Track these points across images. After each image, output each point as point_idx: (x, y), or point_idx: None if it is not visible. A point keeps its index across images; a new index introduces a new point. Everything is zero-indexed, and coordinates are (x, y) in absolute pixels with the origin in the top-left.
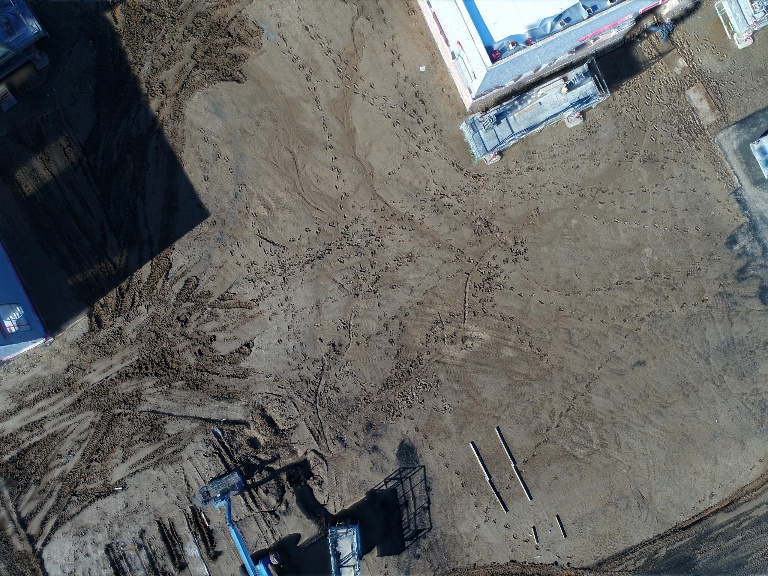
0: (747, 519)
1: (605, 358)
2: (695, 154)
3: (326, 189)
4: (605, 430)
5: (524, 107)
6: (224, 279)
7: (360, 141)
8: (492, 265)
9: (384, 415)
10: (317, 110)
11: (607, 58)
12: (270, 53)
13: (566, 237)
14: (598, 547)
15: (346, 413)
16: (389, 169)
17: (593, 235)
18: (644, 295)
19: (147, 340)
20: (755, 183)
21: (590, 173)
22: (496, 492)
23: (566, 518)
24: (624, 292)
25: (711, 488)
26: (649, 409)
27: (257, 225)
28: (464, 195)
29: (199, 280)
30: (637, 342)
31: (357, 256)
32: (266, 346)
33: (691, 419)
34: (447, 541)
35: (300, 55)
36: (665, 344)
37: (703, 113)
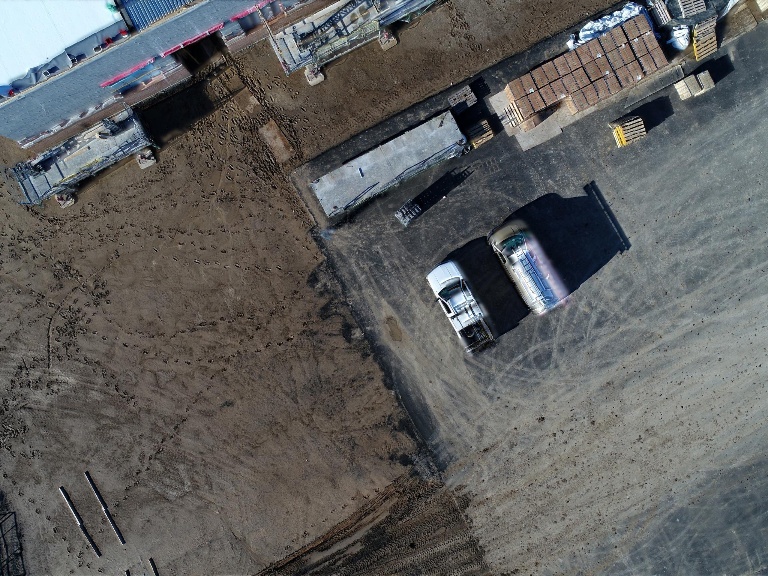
0: (341, 557)
1: (192, 400)
2: (272, 193)
3: None
4: (196, 472)
5: (73, 152)
6: None
7: None
8: (74, 309)
9: None
10: None
11: (177, 98)
12: None
13: (147, 279)
14: None
15: None
16: None
17: (174, 276)
18: (228, 335)
19: None
20: (331, 221)
21: (168, 214)
22: (88, 537)
23: (160, 561)
24: (208, 333)
25: (304, 527)
26: (239, 450)
27: None
28: (41, 239)
29: None
30: (224, 383)
31: None
32: None
33: (281, 459)
34: None
35: None
36: (252, 384)
37: (278, 151)
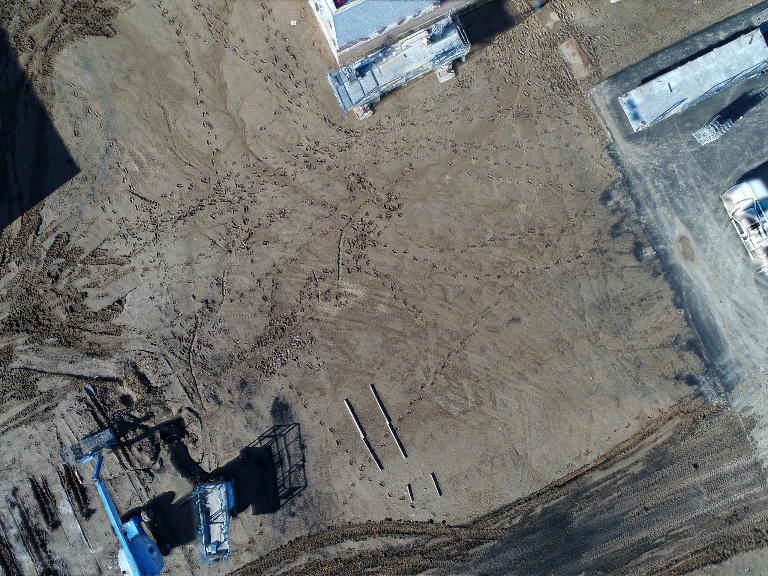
0: (623, 477)
1: (480, 315)
2: (568, 109)
3: (198, 144)
4: (480, 387)
5: (389, 59)
6: (95, 235)
7: (231, 96)
8: (366, 221)
9: (258, 372)
10: (188, 65)
11: (479, 12)
12: (140, 7)
13: (440, 193)
14: (473, 505)
15: (220, 370)
16: (261, 124)
17: (467, 191)
18: (518, 251)
19: (18, 296)
20: (628, 138)
21: (463, 128)
22: (371, 450)
23: (441, 476)
24: (498, 248)
25: (586, 445)
26: (524, 366)
27: (128, 181)
28: (337, 151)
29: (70, 236)
30: (512, 299)
31: (229, 212)
32: (138, 303)
33: (566, 376)
34: (322, 499)
35: (170, 9)
36: (540, 301)
37: (576, 68)
